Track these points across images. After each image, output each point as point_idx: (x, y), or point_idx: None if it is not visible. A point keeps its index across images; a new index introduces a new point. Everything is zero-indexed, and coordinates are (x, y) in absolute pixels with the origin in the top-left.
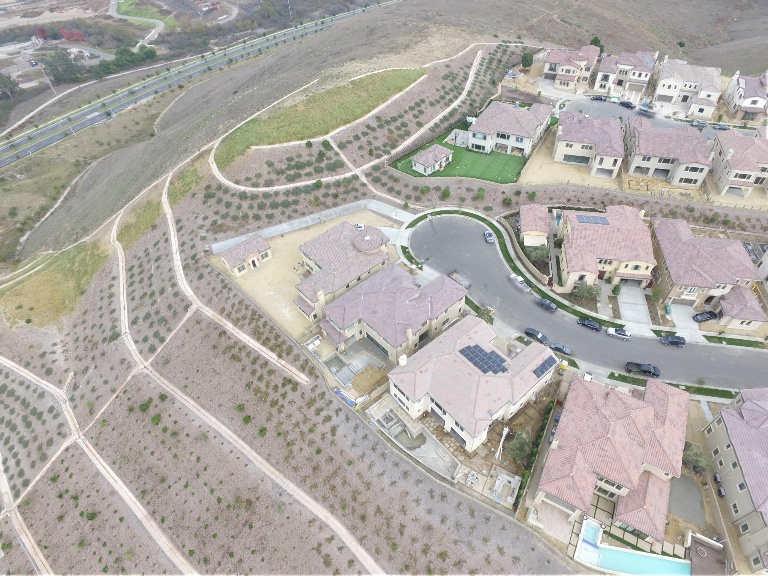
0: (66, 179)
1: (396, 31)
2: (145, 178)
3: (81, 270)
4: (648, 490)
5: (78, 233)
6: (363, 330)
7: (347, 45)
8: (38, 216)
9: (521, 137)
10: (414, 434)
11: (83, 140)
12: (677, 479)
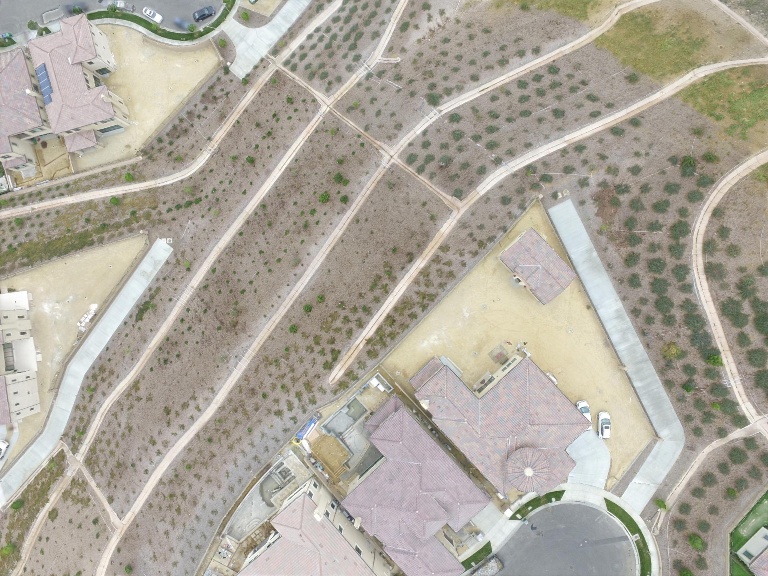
0: None
1: None
2: None
3: None
4: None
5: None
6: None
7: None
8: None
9: None
10: None
11: None
12: None
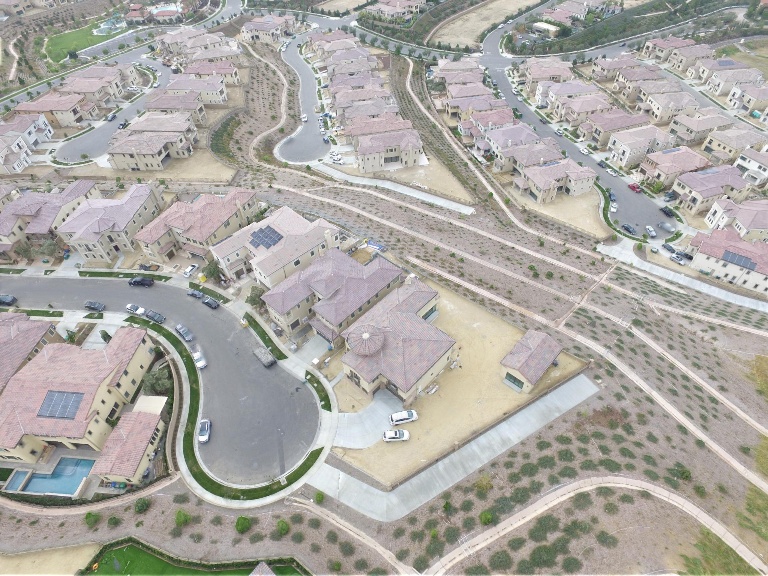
0: None
1: None
2: None
3: None
4: None
5: None
6: None
7: None
8: None
9: None
10: None
11: None
12: None
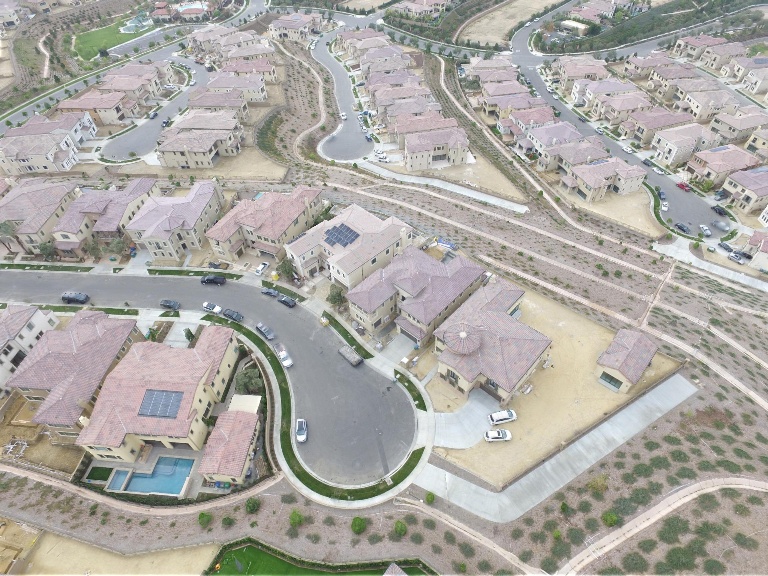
0: None
1: None
2: None
3: None
4: None
5: None
6: None
7: None
8: None
9: None
10: None
11: None
12: None
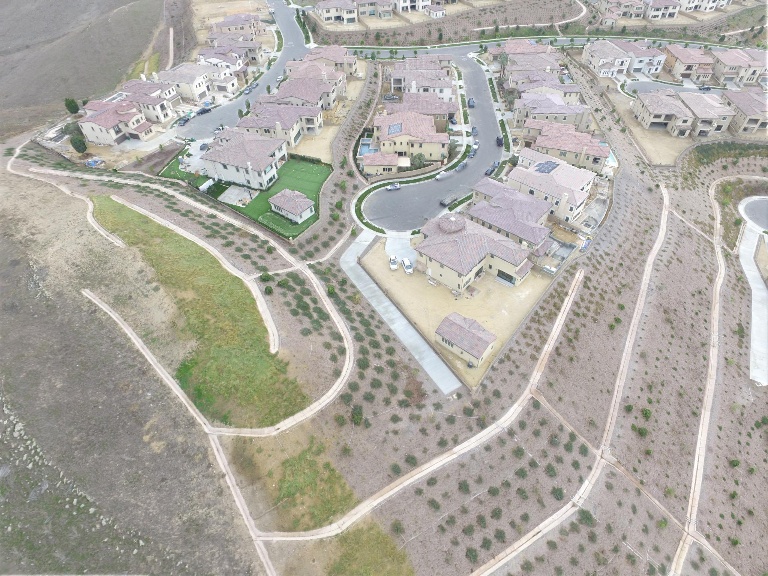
0: None
1: None
2: None
3: None
4: None
5: None
6: None
7: None
8: None
9: None
10: None
11: None
12: None
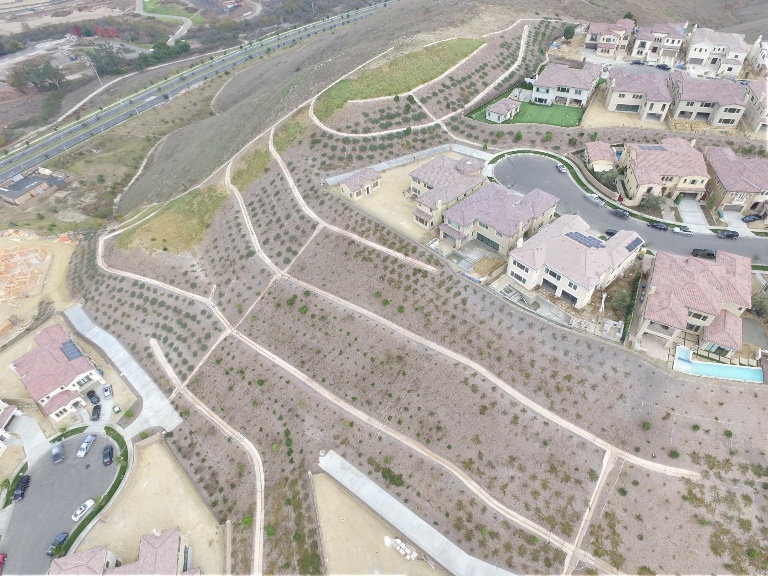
0: (141, 152)
1: (449, 9)
2: (245, 135)
3: (202, 209)
4: (726, 321)
5: (185, 184)
6: (475, 232)
7: (408, 21)
8: (125, 182)
9: (580, 89)
10: (530, 301)
11: (148, 119)
12: (744, 321)
